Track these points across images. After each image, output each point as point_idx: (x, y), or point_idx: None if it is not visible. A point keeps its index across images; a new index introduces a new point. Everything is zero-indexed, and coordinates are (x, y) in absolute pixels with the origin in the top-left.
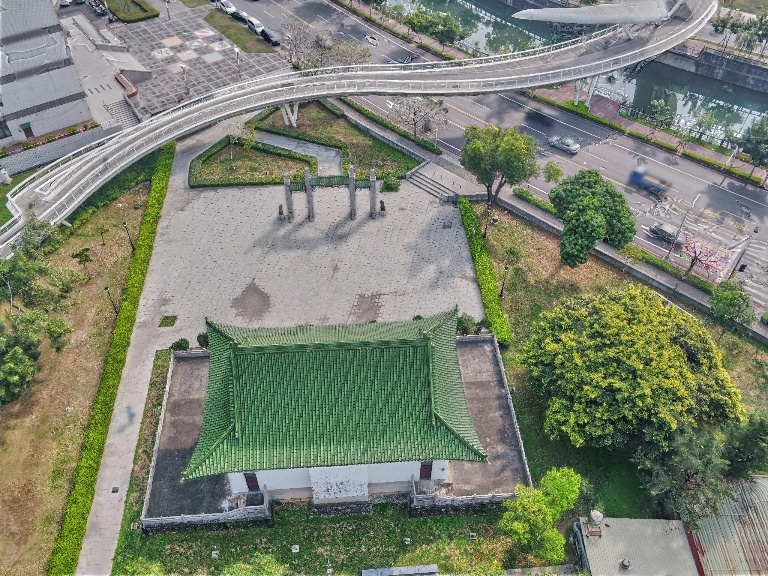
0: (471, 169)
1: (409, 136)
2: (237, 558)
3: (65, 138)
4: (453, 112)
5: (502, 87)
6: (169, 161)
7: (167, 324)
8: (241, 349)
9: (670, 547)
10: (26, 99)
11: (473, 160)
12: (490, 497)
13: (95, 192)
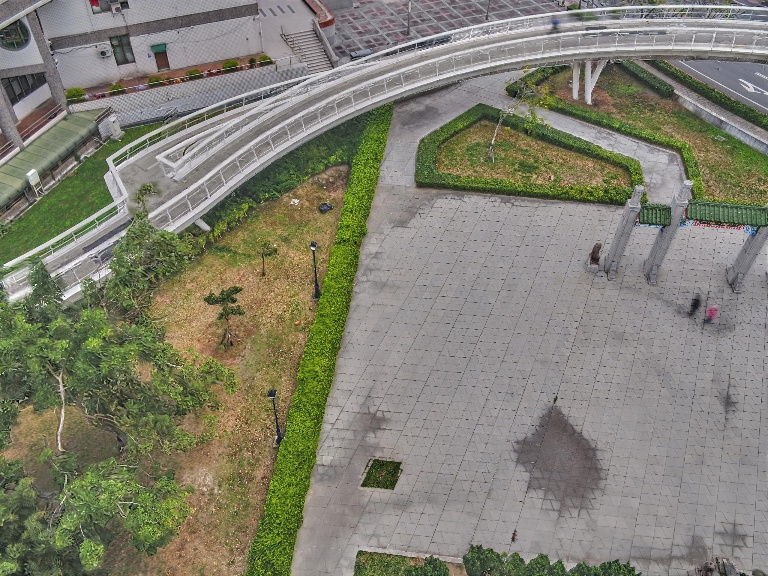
0: None
1: None
2: None
3: (217, 76)
4: None
5: None
6: (383, 135)
7: (381, 481)
8: None
9: None
10: (166, 2)
11: None
12: None
13: (257, 173)
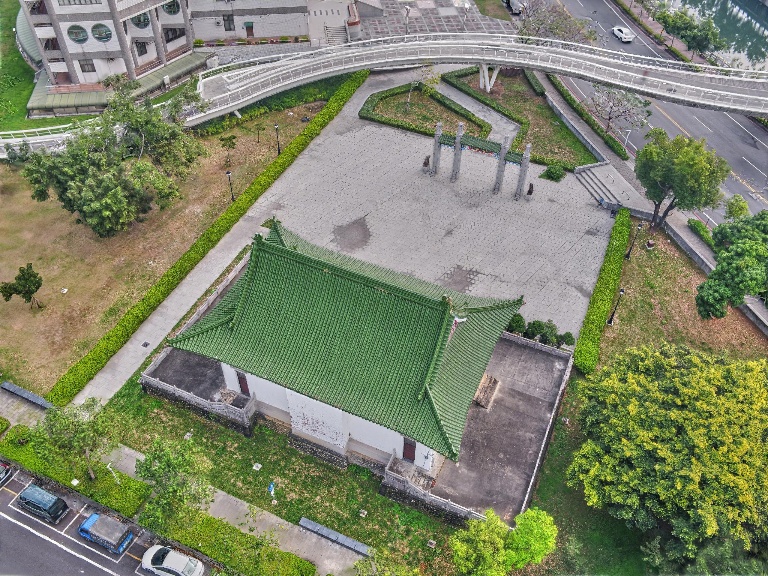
0: (640, 177)
1: (600, 132)
2: (204, 449)
3: (276, 44)
4: (667, 123)
5: (727, 104)
6: (352, 88)
7: (269, 226)
8: (265, 244)
9: None
10: None
11: (645, 167)
12: (466, 511)
13: (274, 95)
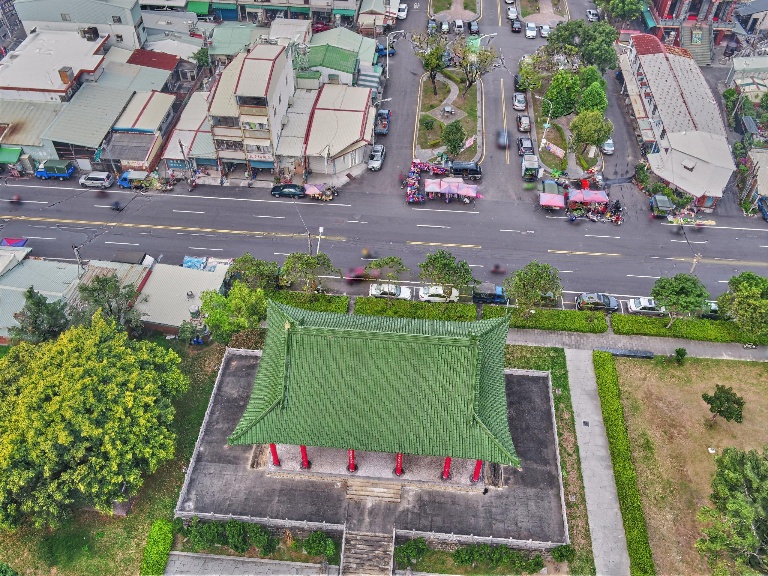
0: None
1: None
2: None
3: None
4: None
5: None
6: None
7: None
8: None
9: (150, 303)
10: None
11: None
12: None
13: None
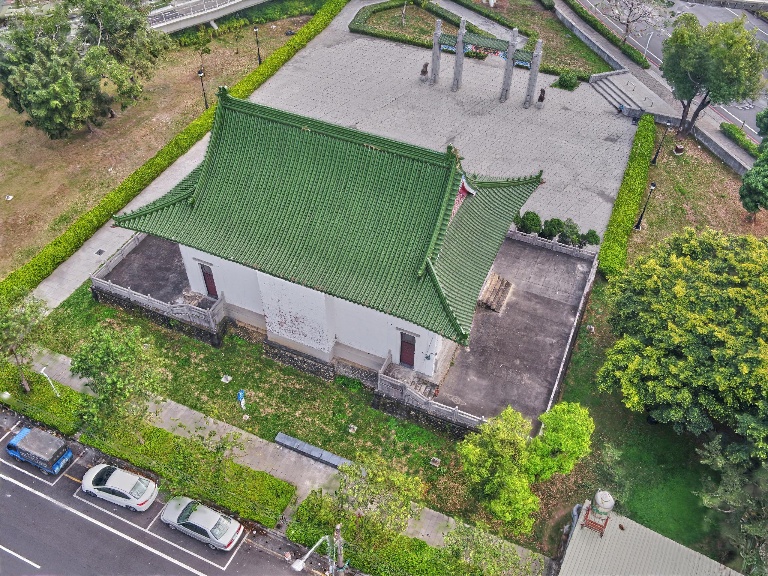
0: (668, 72)
1: (617, 41)
2: None
3: None
4: None
5: None
6: (341, 1)
7: None
8: (231, 101)
9: None
10: None
11: (674, 59)
12: (476, 421)
13: (255, 7)
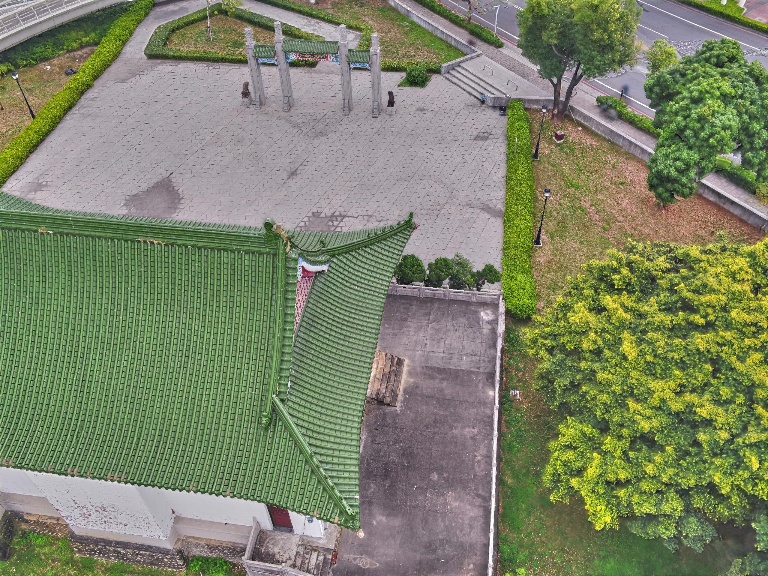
0: (529, 49)
1: (461, 21)
2: None
3: None
4: None
5: None
6: (130, 23)
7: None
8: None
9: None
10: None
11: (532, 33)
12: None
13: (18, 46)
